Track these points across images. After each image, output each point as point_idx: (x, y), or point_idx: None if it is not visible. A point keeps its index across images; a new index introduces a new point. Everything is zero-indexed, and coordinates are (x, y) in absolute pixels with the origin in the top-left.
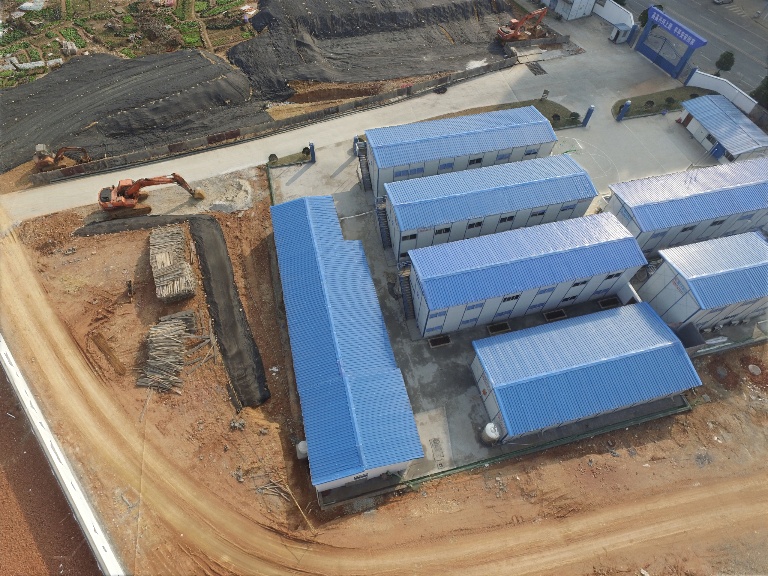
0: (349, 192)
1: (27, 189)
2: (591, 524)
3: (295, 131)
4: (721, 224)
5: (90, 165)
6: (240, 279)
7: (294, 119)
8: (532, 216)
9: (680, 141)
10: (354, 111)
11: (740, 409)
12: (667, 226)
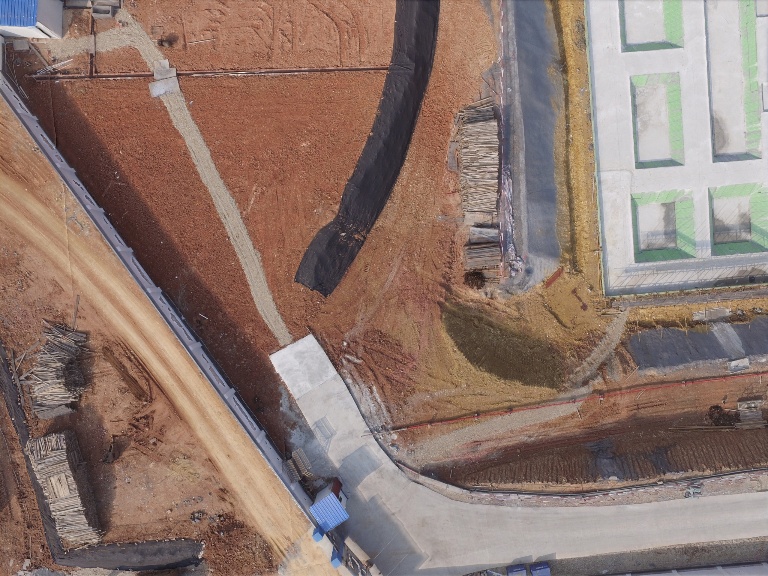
0: None
1: None
2: None
3: None
4: None
5: None
6: (20, 462)
7: None
8: None
9: None
10: None
11: None
12: None
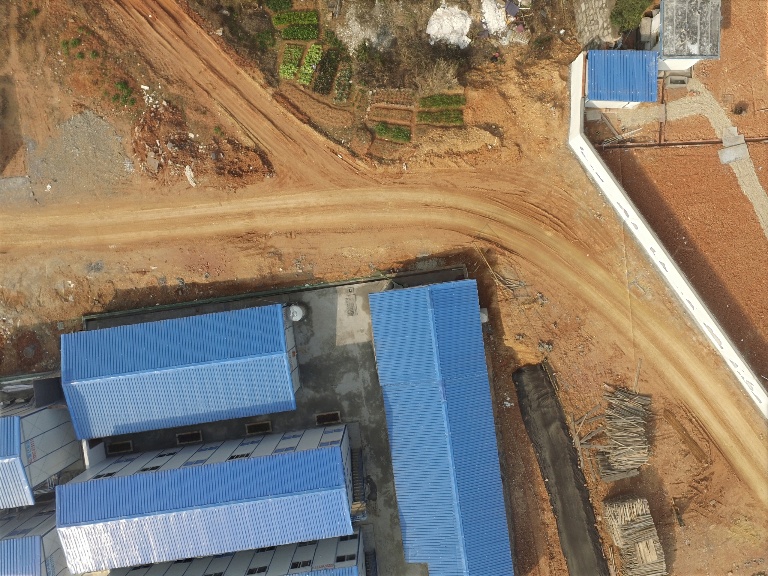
0: None
1: None
2: (226, 225)
3: None
4: None
5: None
6: (550, 523)
7: None
8: None
9: None
10: None
11: (31, 311)
12: (4, 543)
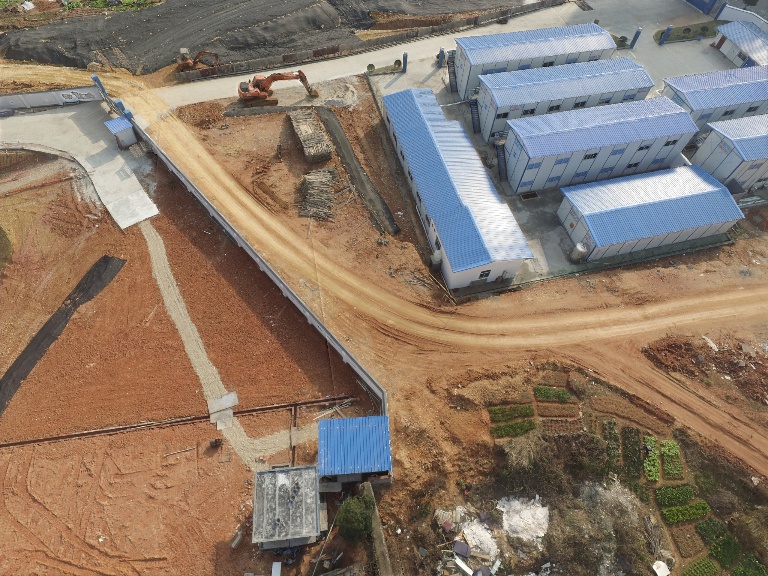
0: (438, 94)
1: (174, 85)
2: (662, 309)
3: (383, 50)
4: (755, 111)
5: (222, 68)
6: (359, 154)
7: (382, 40)
8: (600, 103)
9: (714, 60)
10: (431, 36)
11: None
12: (713, 107)
